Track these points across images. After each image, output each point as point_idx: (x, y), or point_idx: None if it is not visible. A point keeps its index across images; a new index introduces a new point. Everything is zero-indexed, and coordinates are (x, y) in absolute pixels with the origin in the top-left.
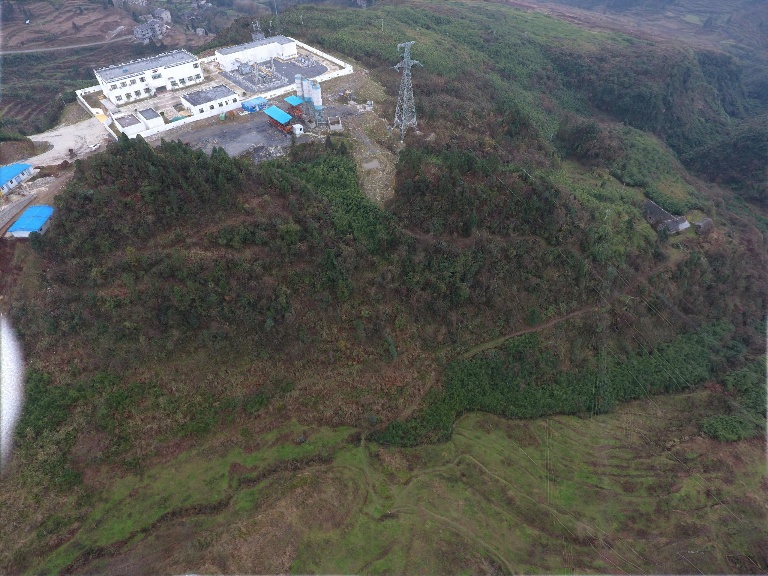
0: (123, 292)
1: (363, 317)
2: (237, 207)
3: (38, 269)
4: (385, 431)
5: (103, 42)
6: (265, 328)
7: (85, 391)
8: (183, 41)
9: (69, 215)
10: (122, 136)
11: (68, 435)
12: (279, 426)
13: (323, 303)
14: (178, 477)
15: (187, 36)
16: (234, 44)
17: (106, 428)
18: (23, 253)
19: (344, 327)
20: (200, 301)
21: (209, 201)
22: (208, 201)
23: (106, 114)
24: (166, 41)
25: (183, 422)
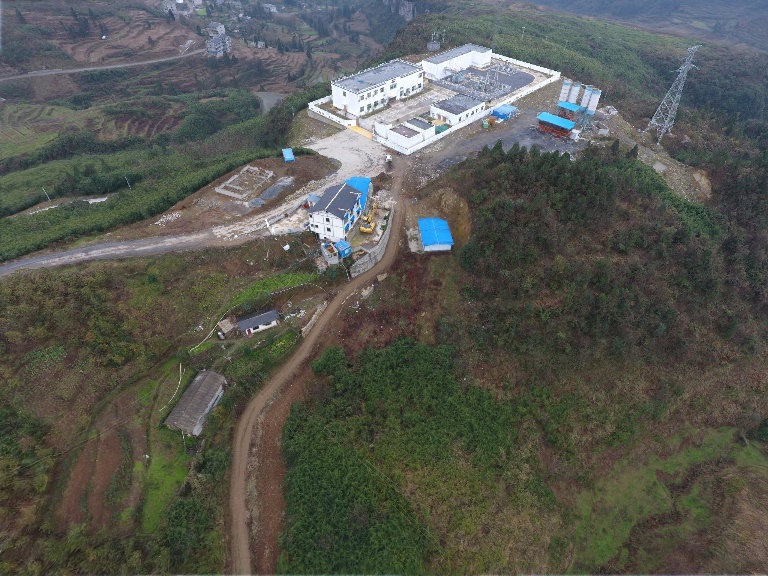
0: (552, 302)
1: (725, 316)
2: (619, 212)
3: (465, 283)
4: (765, 428)
5: (179, 56)
6: (655, 332)
7: (529, 406)
8: (250, 54)
9: (499, 225)
10: (499, 144)
11: (531, 452)
12: (678, 430)
13: (696, 304)
14: (621, 488)
15: (250, 49)
16: None
17: (555, 443)
18: (440, 267)
19: (709, 327)
20: (617, 307)
21: (602, 206)
22: (601, 206)
23: (359, 125)
24: (235, 54)
25: (611, 432)
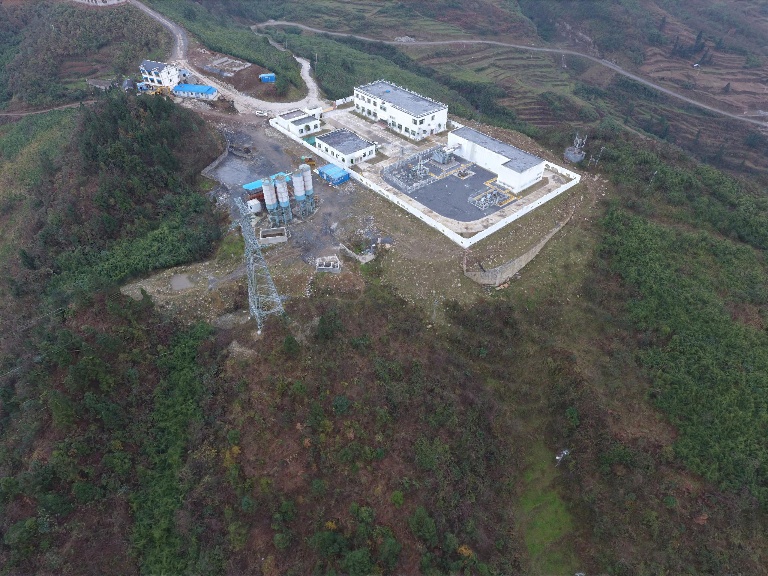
0: None
1: None
2: None
3: None
4: None
5: (729, 114)
6: None
7: None
8: None
9: None
10: None
11: (23, 196)
12: None
13: None
14: None
15: None
16: (546, 144)
17: None
18: None
19: None
20: None
21: None
22: None
23: (334, 109)
24: None
25: (10, 242)
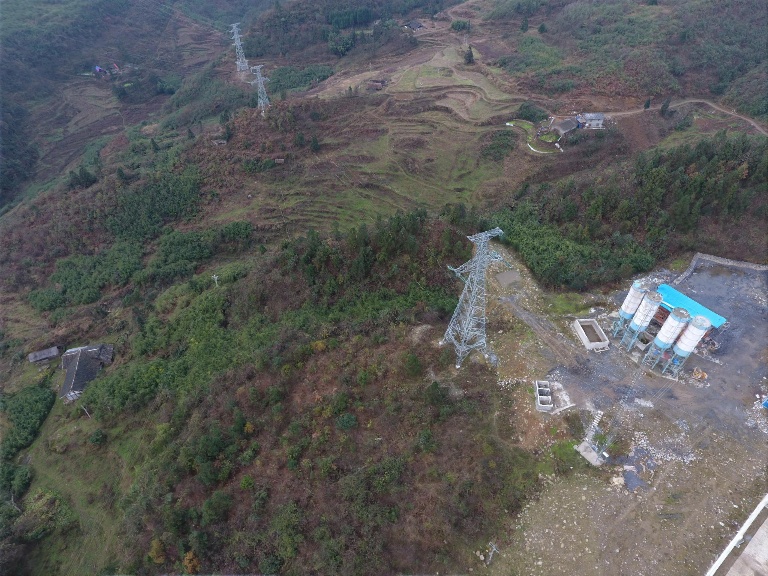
0: None
1: None
2: None
3: None
4: None
5: None
6: None
7: None
8: None
9: None
10: None
11: None
12: None
13: None
14: None
15: None
16: None
17: None
18: None
19: None
20: None
21: None
22: None
23: None
24: None
25: None
